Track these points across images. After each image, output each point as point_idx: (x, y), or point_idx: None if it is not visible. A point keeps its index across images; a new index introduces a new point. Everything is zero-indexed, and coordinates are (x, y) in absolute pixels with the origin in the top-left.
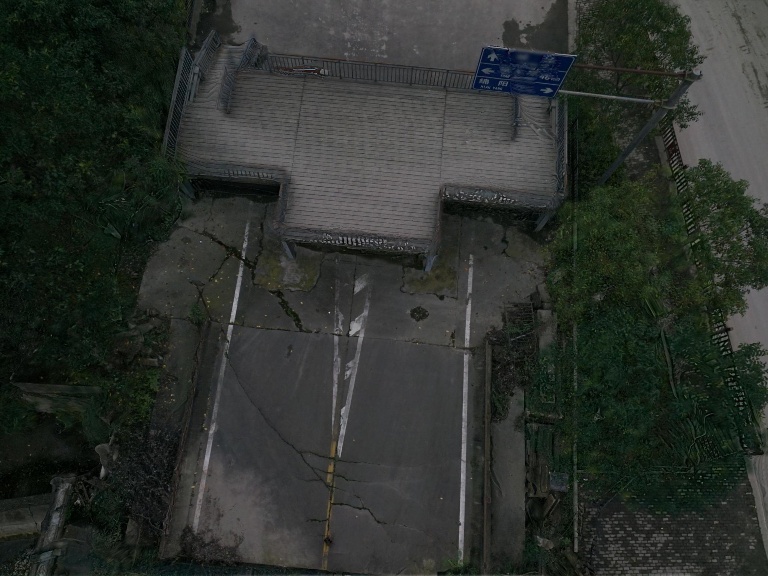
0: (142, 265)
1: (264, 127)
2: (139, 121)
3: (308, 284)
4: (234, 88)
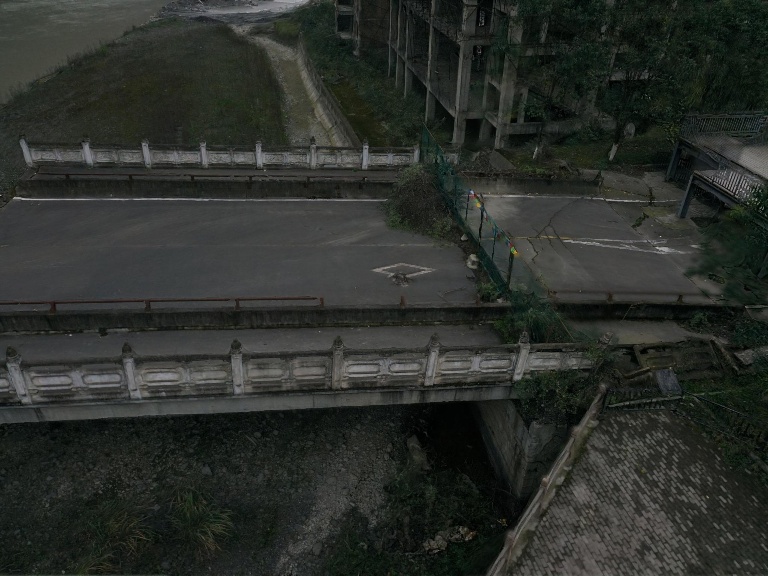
0: (603, 169)
1: (758, 156)
2: (706, 63)
3: (669, 226)
4: (766, 145)
